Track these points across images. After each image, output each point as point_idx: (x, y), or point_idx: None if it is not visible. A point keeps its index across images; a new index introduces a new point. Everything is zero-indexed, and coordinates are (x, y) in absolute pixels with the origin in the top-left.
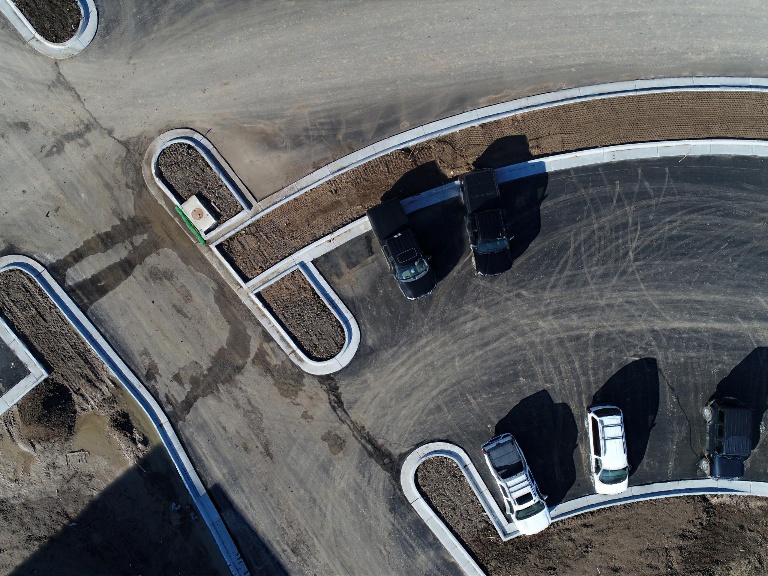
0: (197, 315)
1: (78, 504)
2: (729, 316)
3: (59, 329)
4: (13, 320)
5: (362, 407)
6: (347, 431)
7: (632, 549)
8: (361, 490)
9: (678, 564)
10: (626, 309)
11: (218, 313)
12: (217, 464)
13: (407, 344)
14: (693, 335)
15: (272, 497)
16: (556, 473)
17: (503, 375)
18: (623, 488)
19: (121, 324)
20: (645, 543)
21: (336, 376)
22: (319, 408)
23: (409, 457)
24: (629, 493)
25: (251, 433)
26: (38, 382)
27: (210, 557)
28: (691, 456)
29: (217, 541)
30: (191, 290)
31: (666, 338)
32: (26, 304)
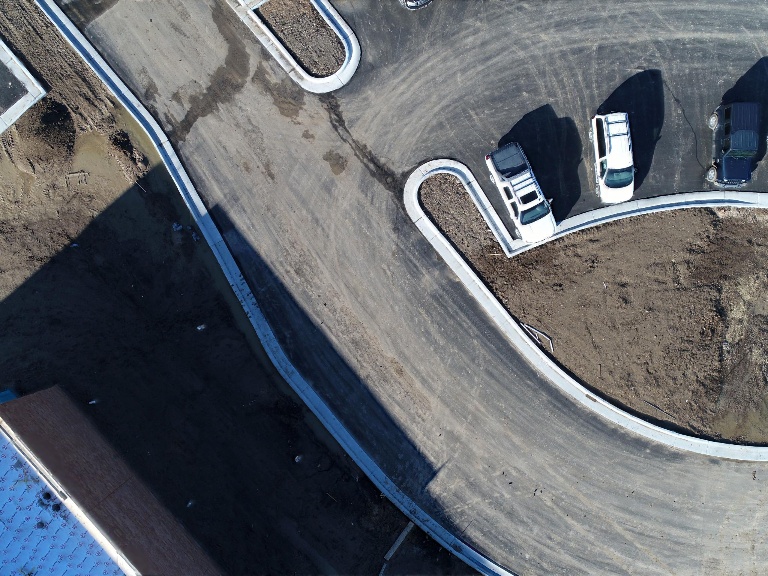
0: (195, 34)
1: (79, 225)
2: (734, 26)
3: (56, 48)
4: (10, 39)
5: (364, 125)
6: (349, 150)
7: (639, 263)
8: (364, 210)
9: (685, 279)
10: (629, 20)
11: (217, 32)
12: (218, 184)
13: (408, 60)
14: (698, 45)
15: (274, 217)
16: (561, 188)
17: (506, 90)
18: (629, 193)
19: (119, 43)
20: (652, 257)
21: (337, 94)
22: (320, 127)
23: (412, 175)
24: (635, 206)
25: (252, 153)
26: (36, 100)
27: (213, 279)
28: (697, 168)
29: (219, 261)
30: (189, 8)
31: (670, 49)
32: (23, 22)
